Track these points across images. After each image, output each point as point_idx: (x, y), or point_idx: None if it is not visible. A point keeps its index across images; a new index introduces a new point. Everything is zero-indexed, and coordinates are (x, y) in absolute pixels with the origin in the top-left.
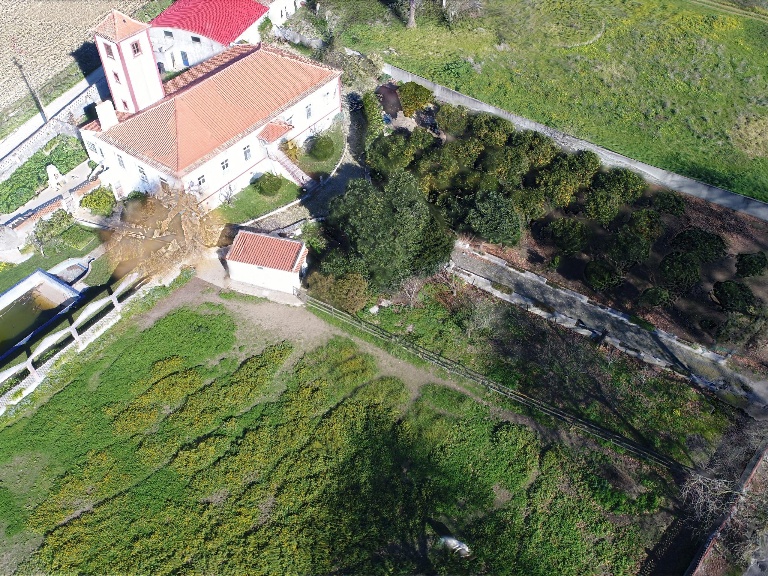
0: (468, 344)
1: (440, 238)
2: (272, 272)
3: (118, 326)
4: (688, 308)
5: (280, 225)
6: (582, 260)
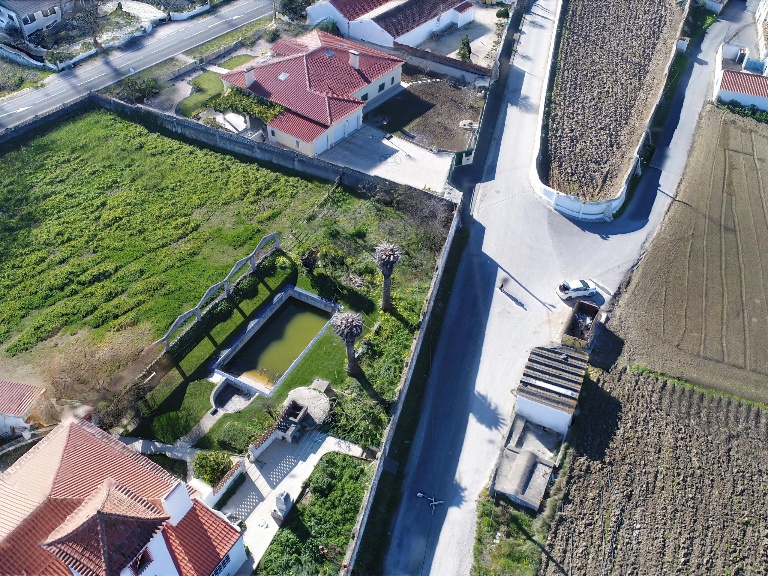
0: None
1: None
2: None
3: None
4: None
5: None
6: None
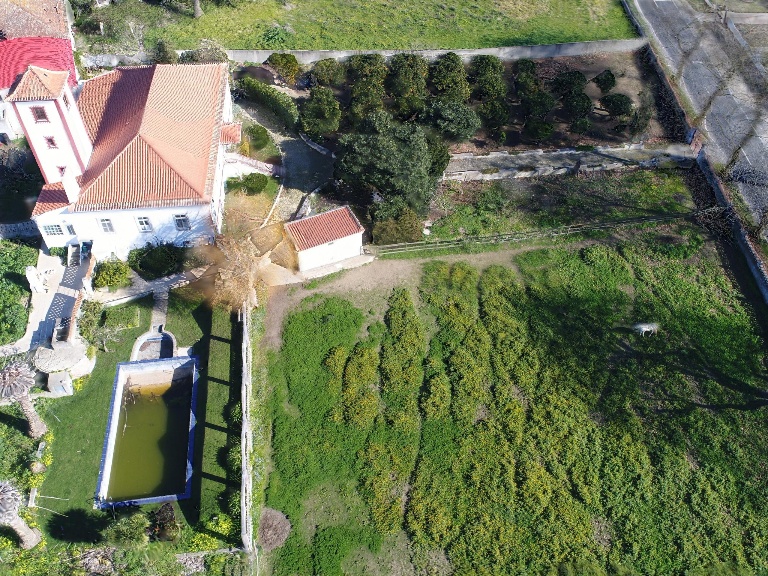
0: (507, 218)
1: (442, 150)
2: (343, 242)
3: (256, 359)
4: (593, 128)
5: (291, 211)
6: (507, 131)
